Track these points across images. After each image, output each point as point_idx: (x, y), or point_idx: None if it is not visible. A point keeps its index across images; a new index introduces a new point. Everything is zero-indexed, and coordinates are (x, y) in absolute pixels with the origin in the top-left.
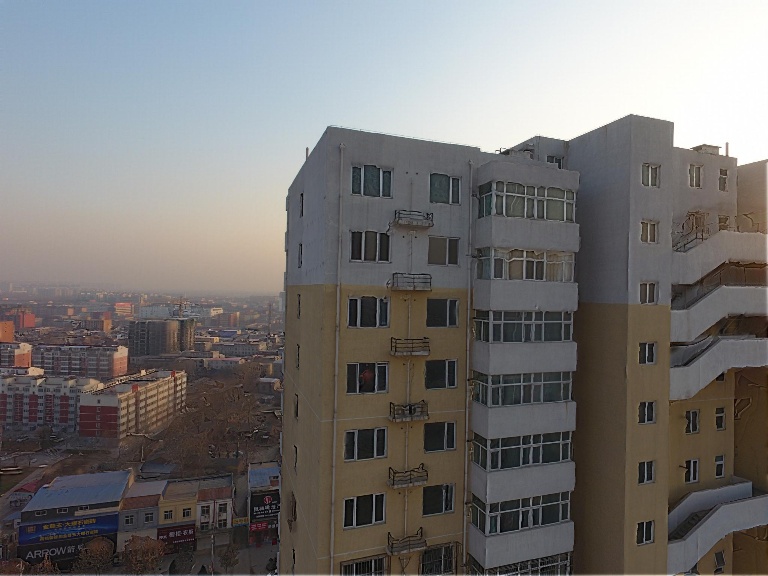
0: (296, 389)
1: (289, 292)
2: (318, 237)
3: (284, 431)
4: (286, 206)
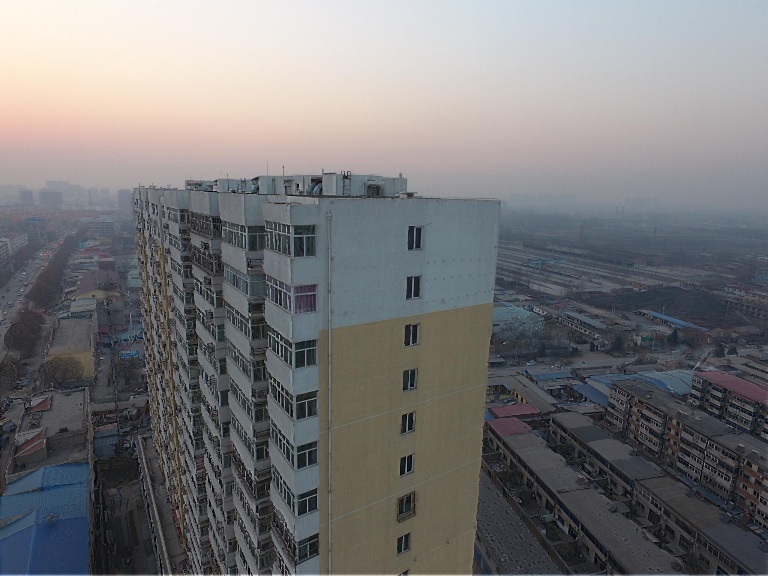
0: (412, 407)
1: (352, 333)
2: (478, 272)
3: (334, 494)
4: (293, 218)
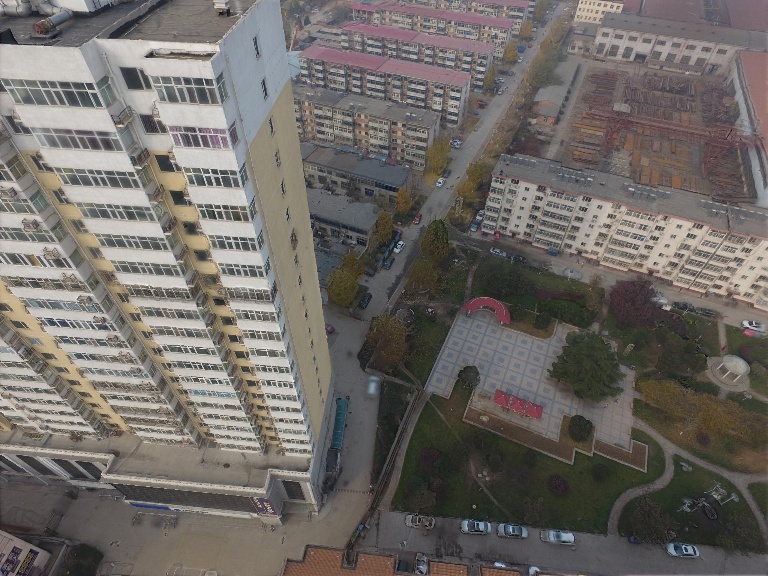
0: None
1: (255, 145)
2: None
3: None
4: (215, 72)
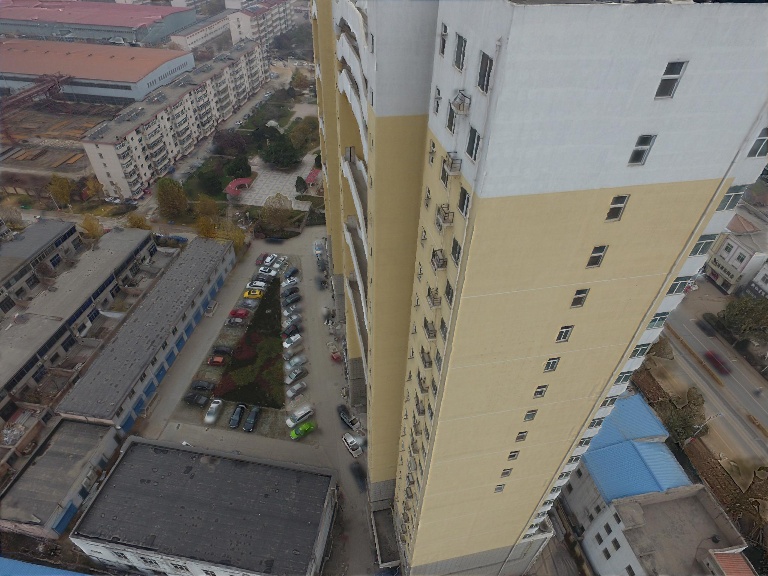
0: None
1: None
2: None
3: None
4: None
